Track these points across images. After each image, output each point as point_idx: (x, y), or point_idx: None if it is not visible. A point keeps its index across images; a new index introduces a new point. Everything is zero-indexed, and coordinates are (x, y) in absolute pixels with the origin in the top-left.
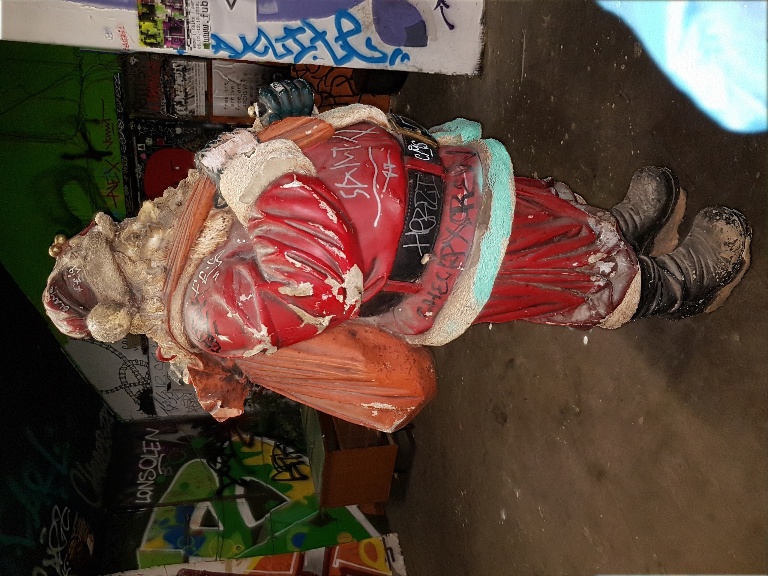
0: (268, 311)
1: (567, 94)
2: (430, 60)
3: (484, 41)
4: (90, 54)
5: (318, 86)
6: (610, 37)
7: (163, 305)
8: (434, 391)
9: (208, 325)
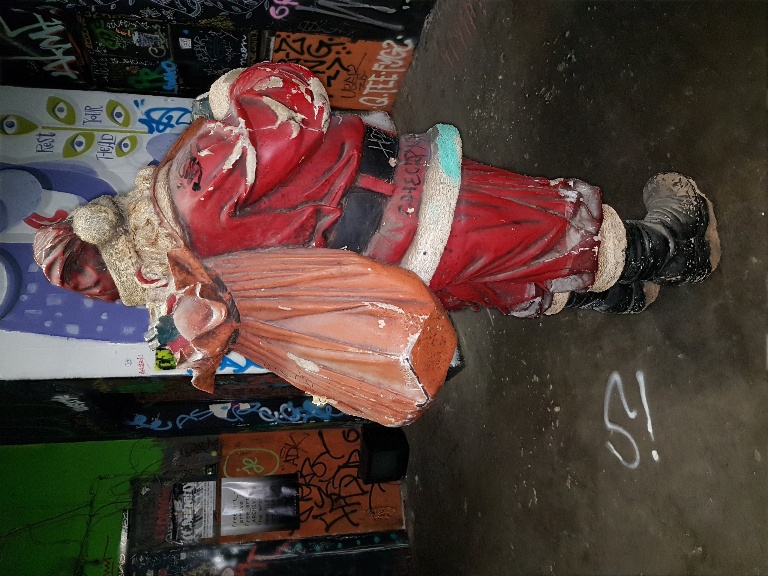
0: (245, 112)
1: None
2: None
3: None
4: (103, 489)
5: (327, 489)
6: None
7: (151, 179)
8: (449, 323)
9: (191, 150)
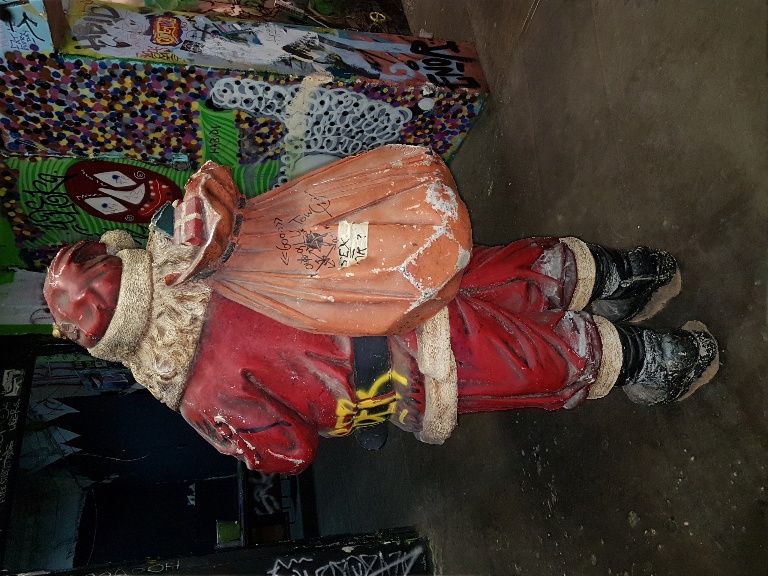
0: None
1: None
2: None
3: None
4: None
5: None
6: (649, 572)
7: None
8: None
9: None
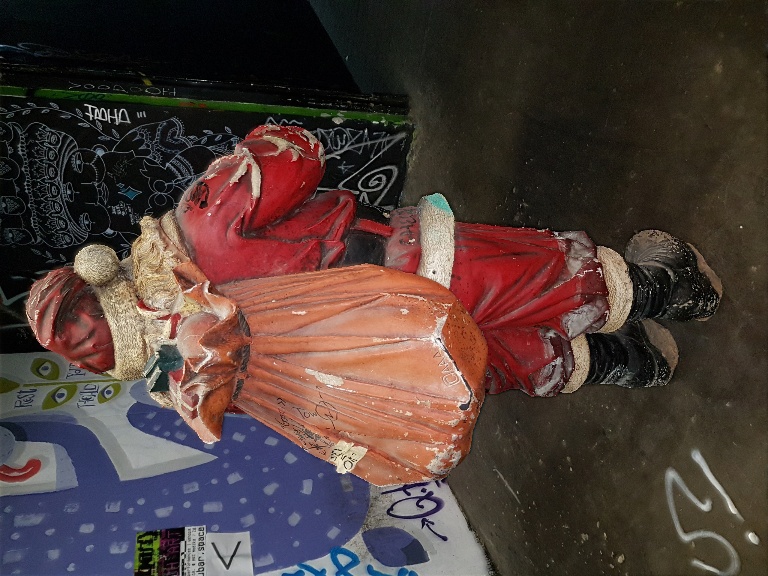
0: None
1: (543, 436)
2: (439, 573)
3: (482, 543)
4: None
5: None
6: None
7: None
8: None
9: None
